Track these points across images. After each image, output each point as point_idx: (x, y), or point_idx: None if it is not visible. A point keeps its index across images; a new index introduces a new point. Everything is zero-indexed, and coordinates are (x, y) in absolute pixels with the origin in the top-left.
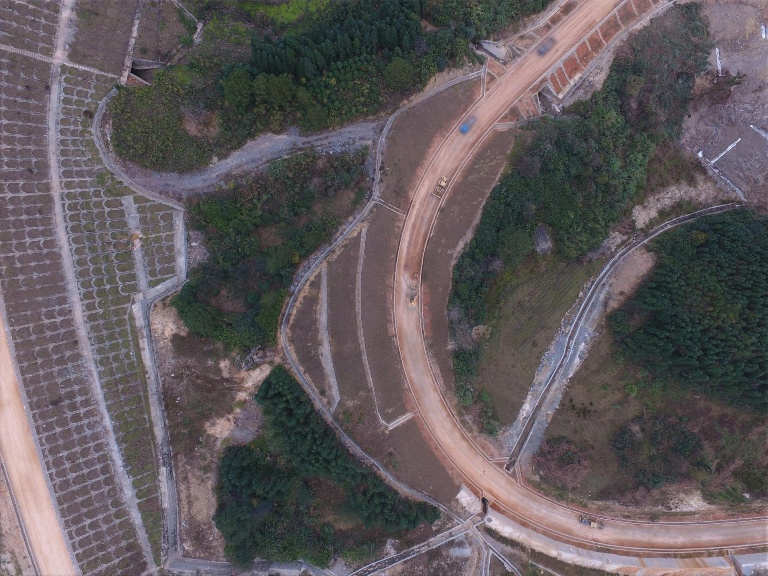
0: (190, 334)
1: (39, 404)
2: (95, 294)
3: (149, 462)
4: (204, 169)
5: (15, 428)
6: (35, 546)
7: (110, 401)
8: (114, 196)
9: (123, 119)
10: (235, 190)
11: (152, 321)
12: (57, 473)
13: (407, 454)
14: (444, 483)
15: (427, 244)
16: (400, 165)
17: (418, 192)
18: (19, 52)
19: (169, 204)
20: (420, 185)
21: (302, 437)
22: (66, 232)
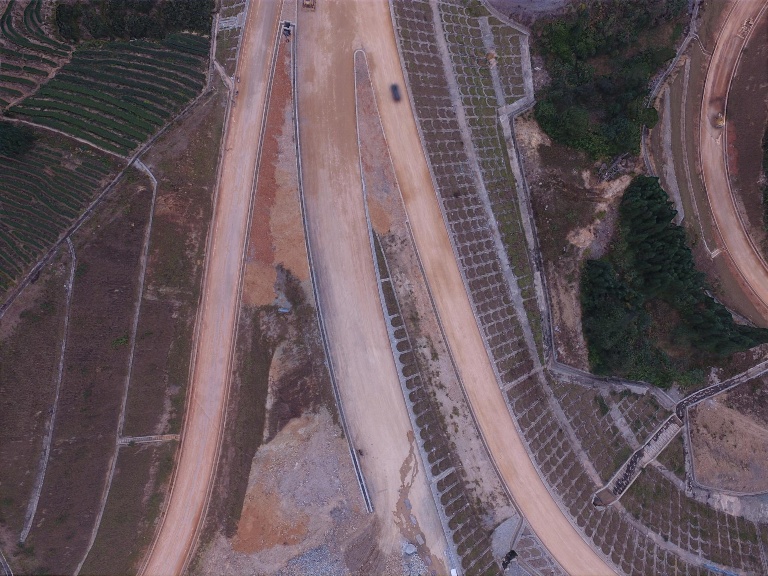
0: (556, 144)
1: (446, 193)
2: (471, 101)
3: (526, 265)
4: None
5: (426, 215)
6: (448, 332)
7: (493, 202)
8: (472, 16)
9: None
10: (583, 12)
11: (517, 132)
12: (466, 260)
13: (727, 283)
14: (757, 315)
15: (731, 84)
16: (714, 3)
17: (722, 34)
18: None
19: (516, 28)
20: (724, 27)
21: (668, 243)
22: (445, 40)
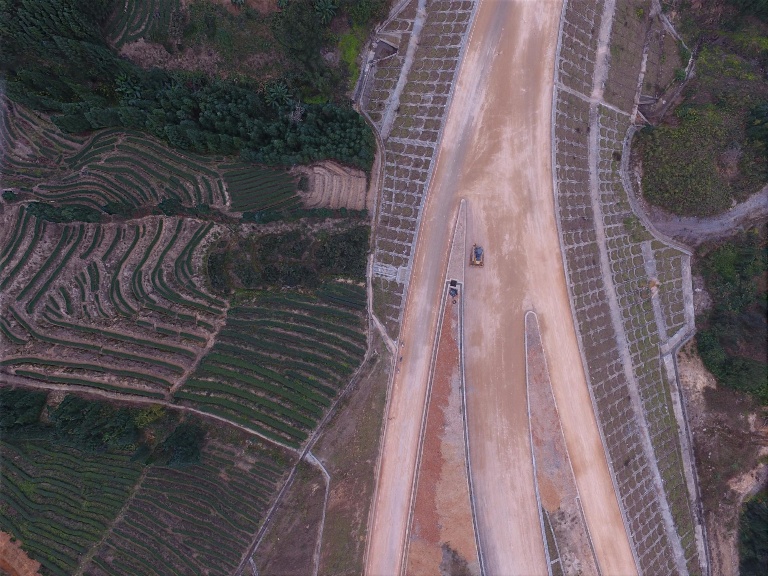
0: (722, 387)
1: (618, 465)
2: (637, 346)
3: (688, 520)
4: (723, 213)
5: (598, 490)
6: None
7: (658, 458)
8: (636, 242)
9: (658, 162)
10: (755, 235)
11: (681, 373)
12: (637, 536)
13: None
14: None
15: None
16: None
17: None
18: (573, 93)
19: (679, 249)
20: None
21: None
22: (613, 282)
